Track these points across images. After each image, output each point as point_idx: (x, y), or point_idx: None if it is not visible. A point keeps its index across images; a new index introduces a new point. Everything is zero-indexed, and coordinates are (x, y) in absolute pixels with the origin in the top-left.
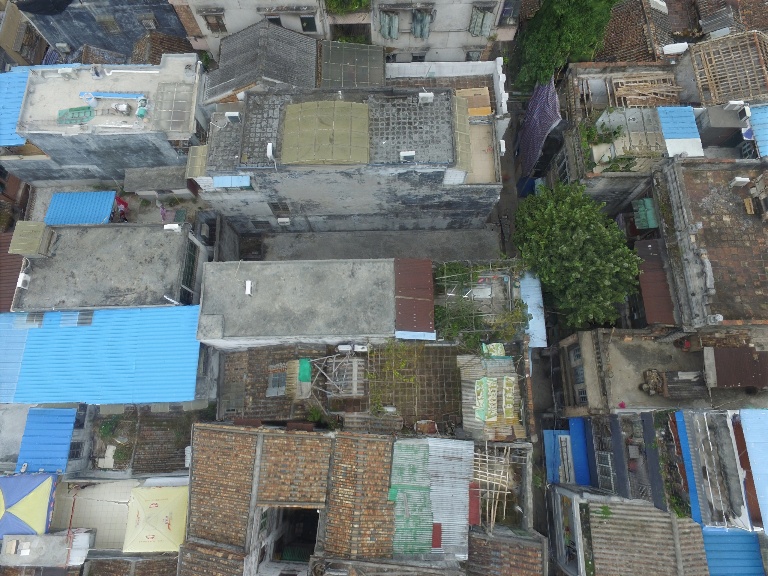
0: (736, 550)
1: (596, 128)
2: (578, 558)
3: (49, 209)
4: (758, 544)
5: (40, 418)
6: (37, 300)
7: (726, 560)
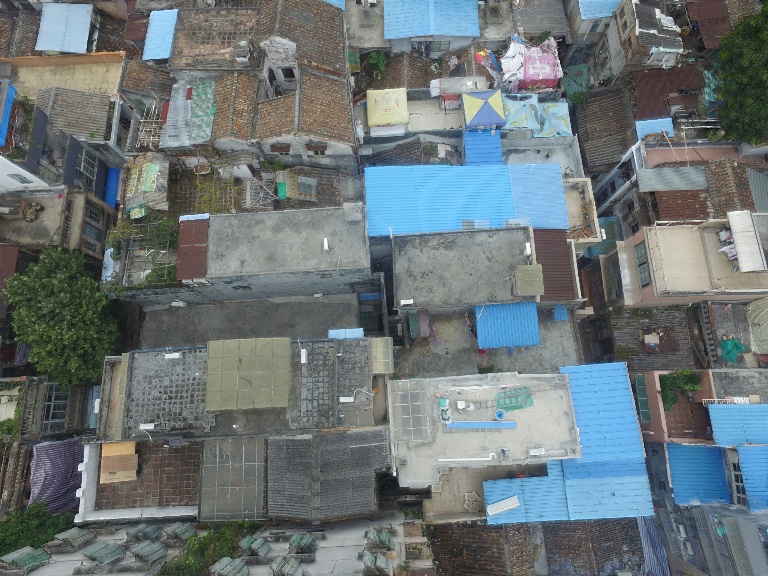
0: None
1: (2, 433)
2: None
3: (537, 327)
4: None
5: None
6: (513, 237)
7: None
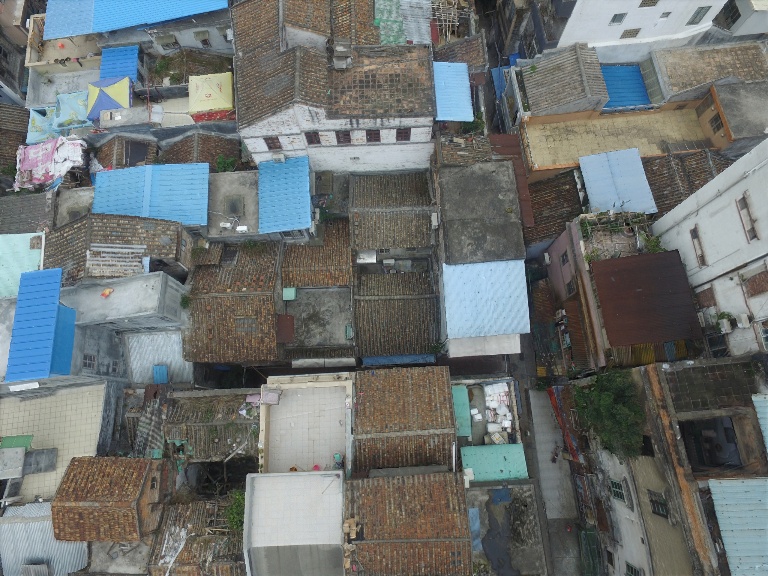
0: (629, 92)
1: None
2: (517, 102)
3: None
4: (645, 88)
5: (111, 54)
6: None
7: (623, 98)
